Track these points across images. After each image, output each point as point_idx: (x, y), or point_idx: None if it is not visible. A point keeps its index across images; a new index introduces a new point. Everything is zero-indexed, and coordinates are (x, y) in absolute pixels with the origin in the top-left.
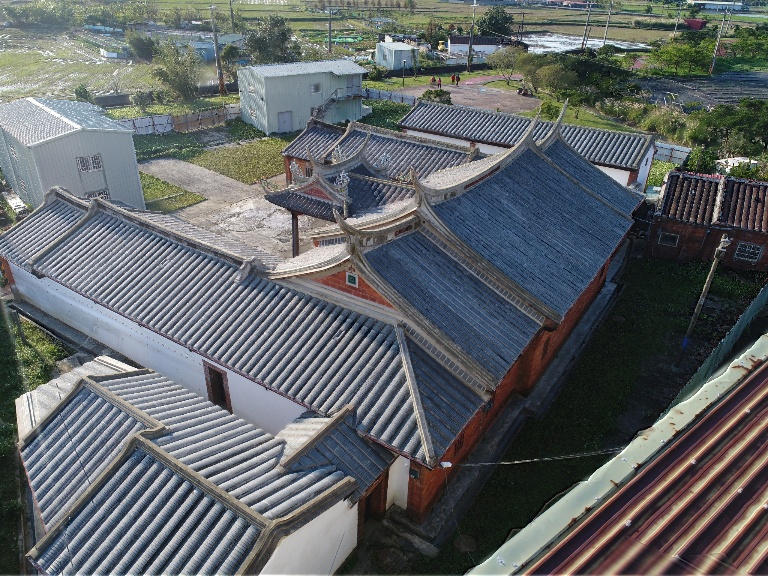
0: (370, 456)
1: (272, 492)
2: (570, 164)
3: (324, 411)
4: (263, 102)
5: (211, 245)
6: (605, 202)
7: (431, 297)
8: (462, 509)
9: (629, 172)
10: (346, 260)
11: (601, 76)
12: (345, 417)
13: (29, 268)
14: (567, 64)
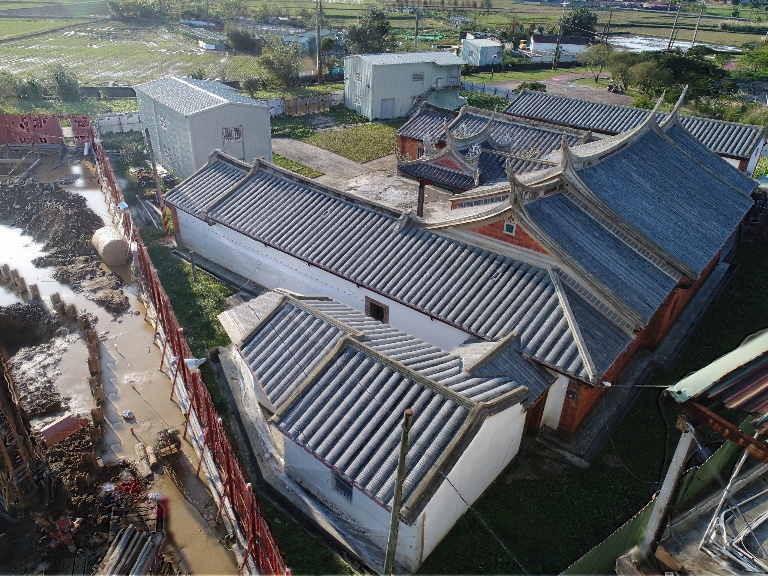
0: (535, 375)
1: (466, 387)
2: (688, 147)
3: (490, 336)
4: (369, 89)
5: None
6: (726, 182)
7: (581, 248)
8: (604, 436)
9: (739, 161)
10: (507, 210)
11: (699, 73)
12: (511, 341)
13: (203, 216)
14: (661, 62)
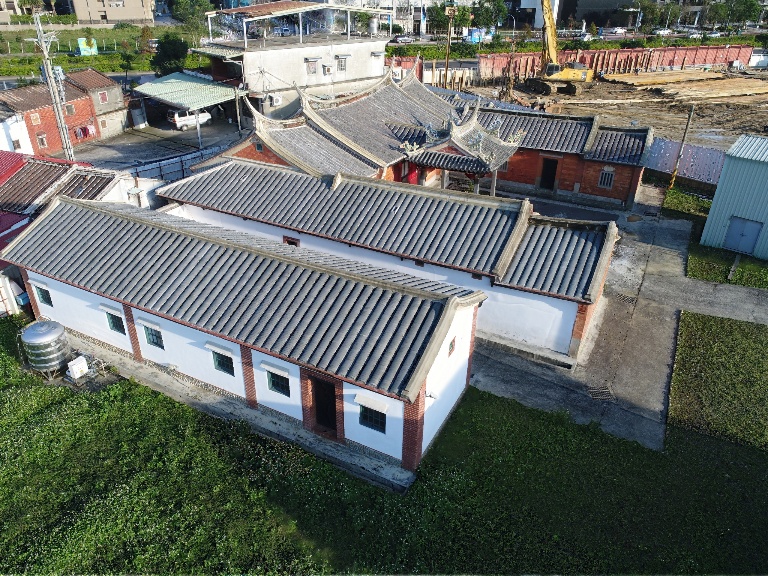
0: None
1: None
2: None
3: None
4: None
5: (494, 108)
6: None
7: None
8: None
9: None
10: None
11: None
12: None
13: None
14: None
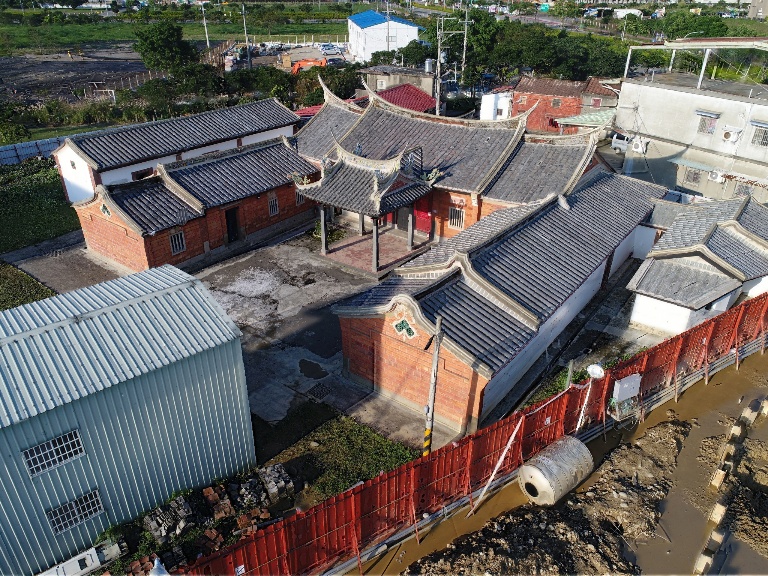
0: None
1: None
2: None
3: None
4: None
5: (540, 205)
6: None
7: None
8: None
9: None
10: None
11: None
12: None
13: None
14: None
